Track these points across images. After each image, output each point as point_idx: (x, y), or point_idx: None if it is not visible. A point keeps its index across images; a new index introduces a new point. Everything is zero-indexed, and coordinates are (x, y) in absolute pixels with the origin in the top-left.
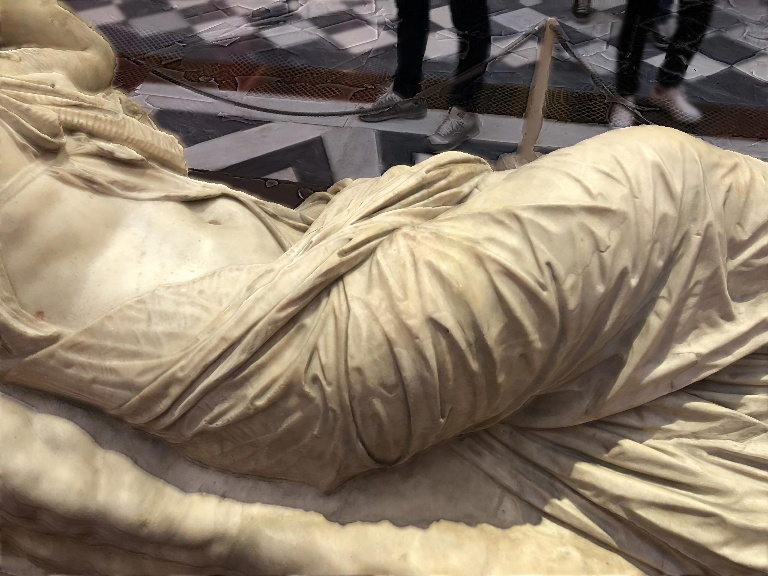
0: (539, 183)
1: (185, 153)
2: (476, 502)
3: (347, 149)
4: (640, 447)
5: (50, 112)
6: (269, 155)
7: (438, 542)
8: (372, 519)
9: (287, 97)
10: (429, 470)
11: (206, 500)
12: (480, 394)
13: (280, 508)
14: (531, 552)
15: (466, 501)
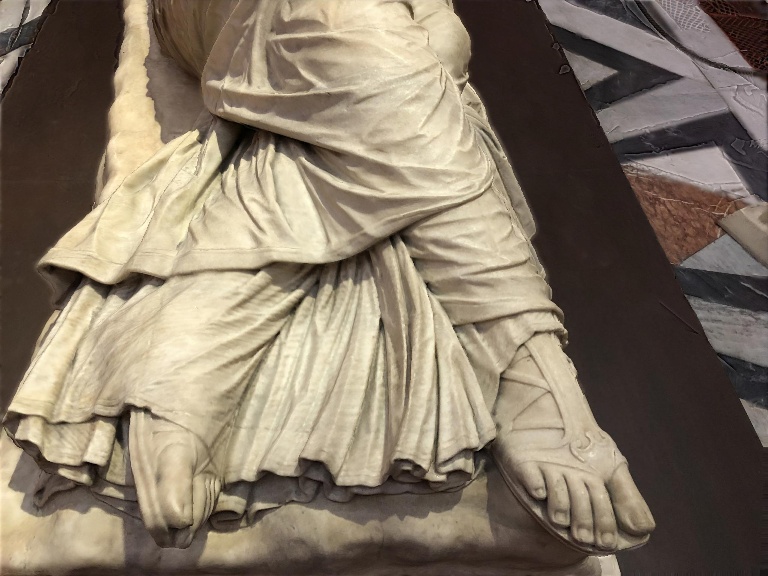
0: None
1: (589, 15)
2: (175, 119)
3: (676, 97)
4: (191, 136)
5: None
6: (624, 55)
7: (140, 104)
8: (149, 74)
9: (662, 3)
10: (192, 91)
11: (143, 7)
12: (170, 10)
13: (148, 38)
14: (146, 154)
15: (173, 112)
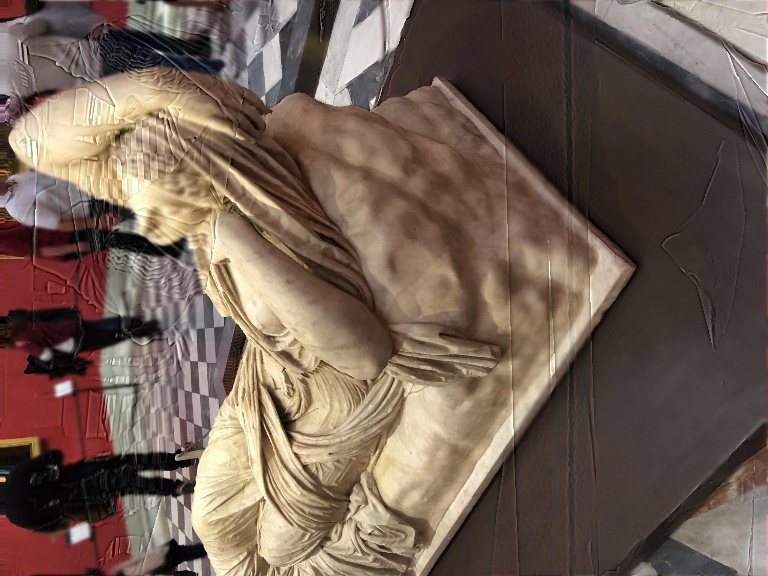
0: (202, 469)
1: None
2: None
3: None
4: None
5: (223, 314)
6: None
7: None
8: None
9: None
10: None
11: None
12: None
13: None
14: None
15: None
